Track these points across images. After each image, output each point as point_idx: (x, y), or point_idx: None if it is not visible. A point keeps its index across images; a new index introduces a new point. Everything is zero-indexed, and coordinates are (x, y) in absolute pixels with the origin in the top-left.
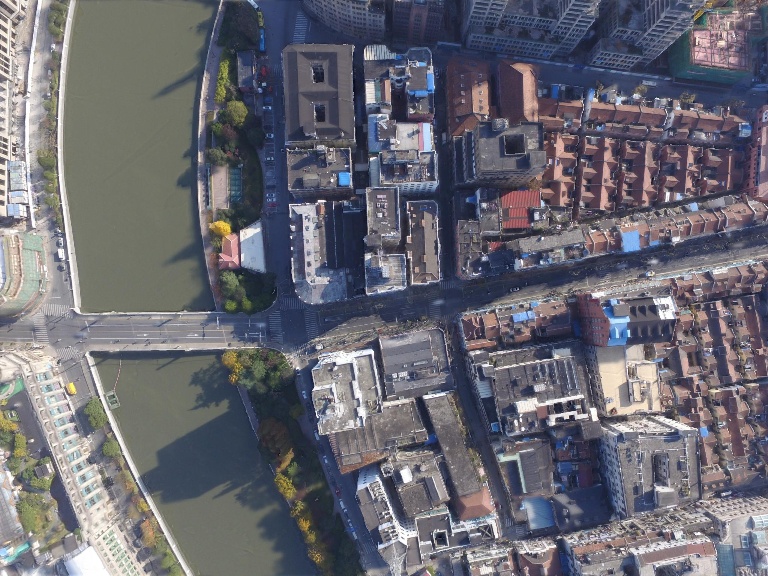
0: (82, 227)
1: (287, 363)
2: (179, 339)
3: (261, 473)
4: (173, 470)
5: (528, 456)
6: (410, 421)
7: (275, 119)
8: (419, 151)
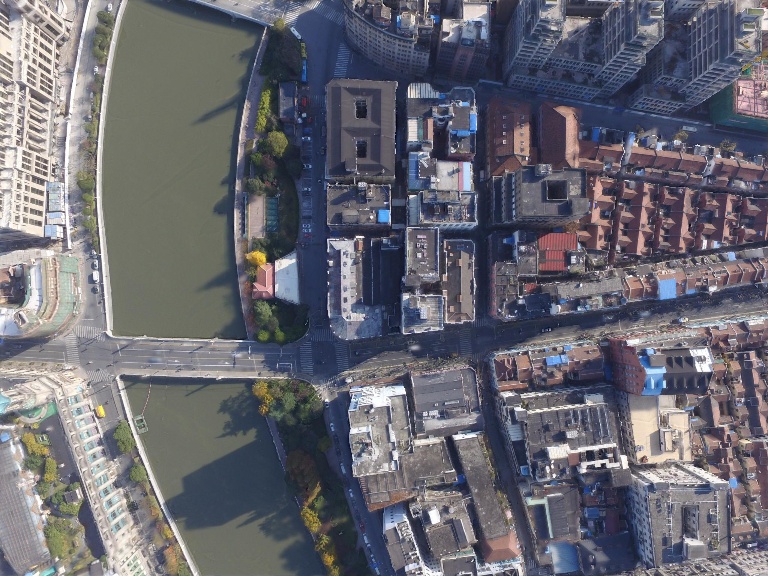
0: (117, 249)
1: (316, 395)
2: (210, 366)
3: (286, 504)
4: (197, 496)
5: (556, 501)
6: (440, 461)
7: (314, 150)
8: (460, 191)
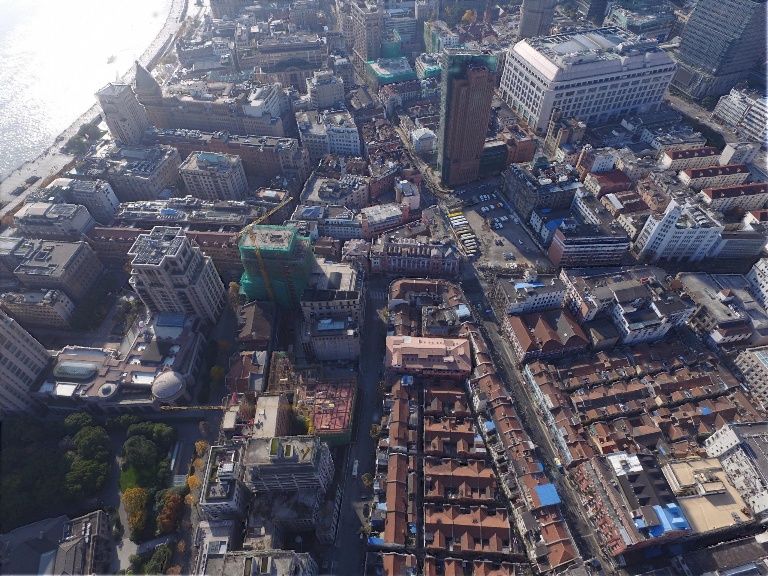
0: None
1: None
2: None
3: None
4: None
5: None
6: None
7: None
8: None
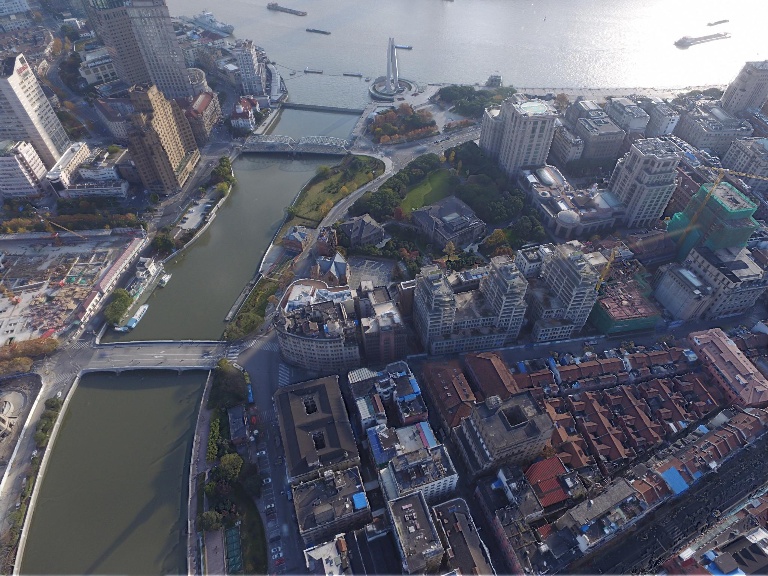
0: None
1: None
2: None
3: None
4: None
5: None
6: None
7: (270, 462)
8: (427, 449)
